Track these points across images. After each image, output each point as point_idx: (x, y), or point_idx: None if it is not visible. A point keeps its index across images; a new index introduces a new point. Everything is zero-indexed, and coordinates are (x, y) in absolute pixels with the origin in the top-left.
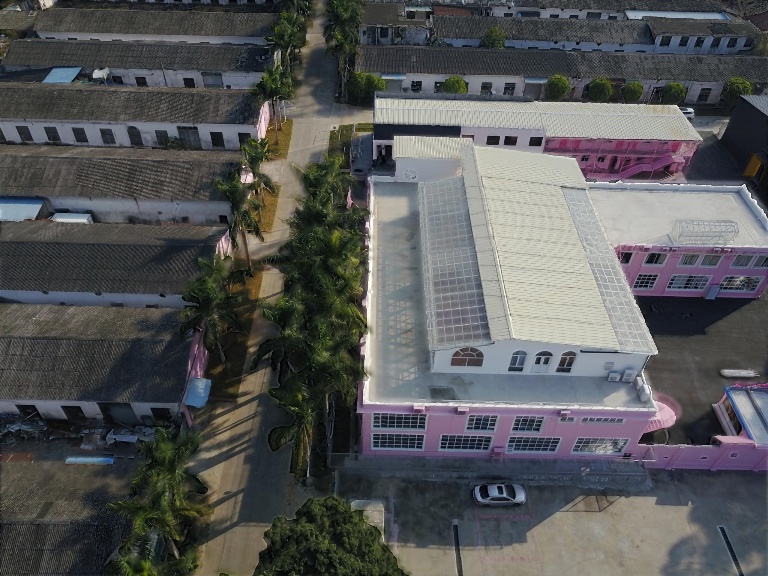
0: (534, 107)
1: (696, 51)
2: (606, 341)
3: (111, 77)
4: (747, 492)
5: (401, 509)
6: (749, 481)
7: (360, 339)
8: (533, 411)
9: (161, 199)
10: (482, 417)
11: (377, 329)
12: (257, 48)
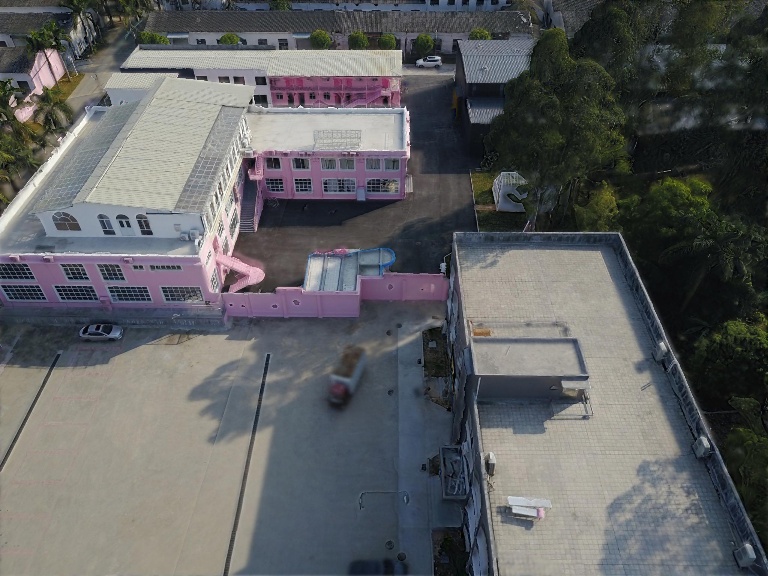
0: (270, 53)
1: (465, 9)
2: (165, 205)
3: None
4: (304, 331)
5: (21, 343)
6: (311, 324)
7: None
8: (104, 259)
9: None
10: (73, 267)
11: (23, 210)
12: (61, 14)
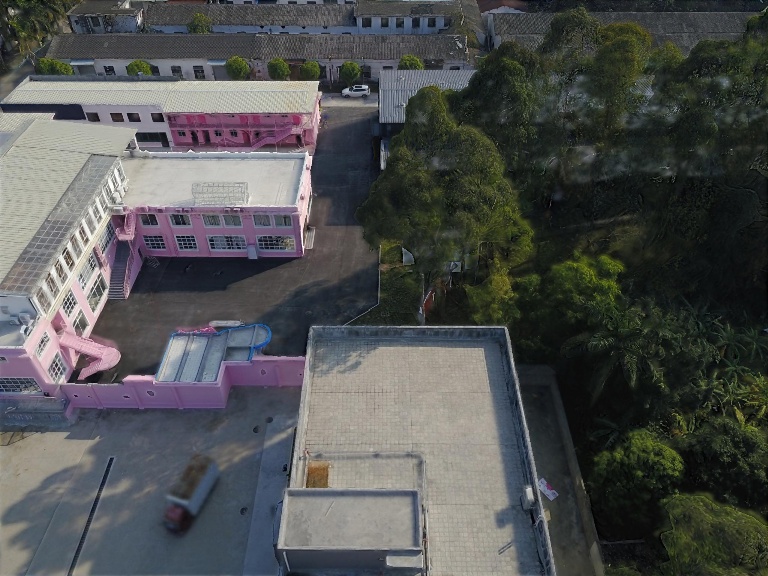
0: (172, 86)
1: (400, 32)
2: None
3: None
4: (159, 427)
5: None
6: (169, 418)
7: None
8: None
9: None
10: None
11: None
12: None
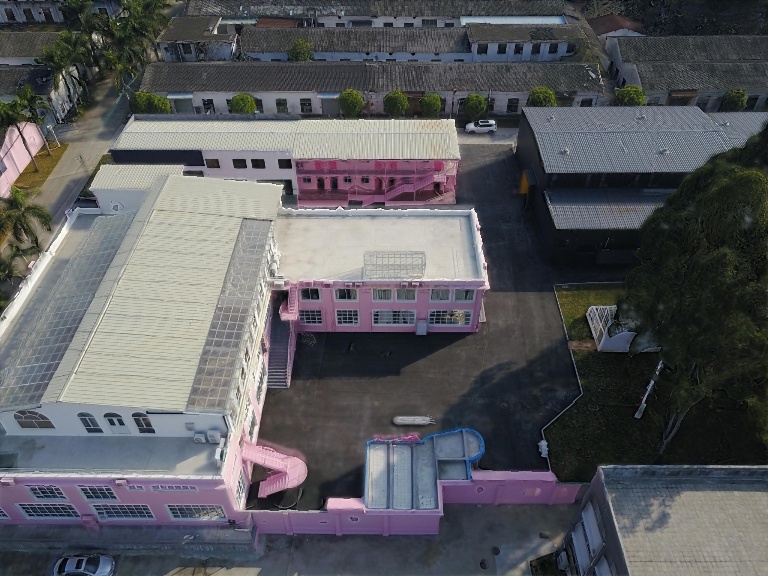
0: (295, 126)
1: (517, 58)
2: (172, 401)
3: None
4: (366, 561)
5: None
6: (374, 547)
7: None
8: (87, 480)
9: None
10: (43, 486)
11: None
12: (40, 70)
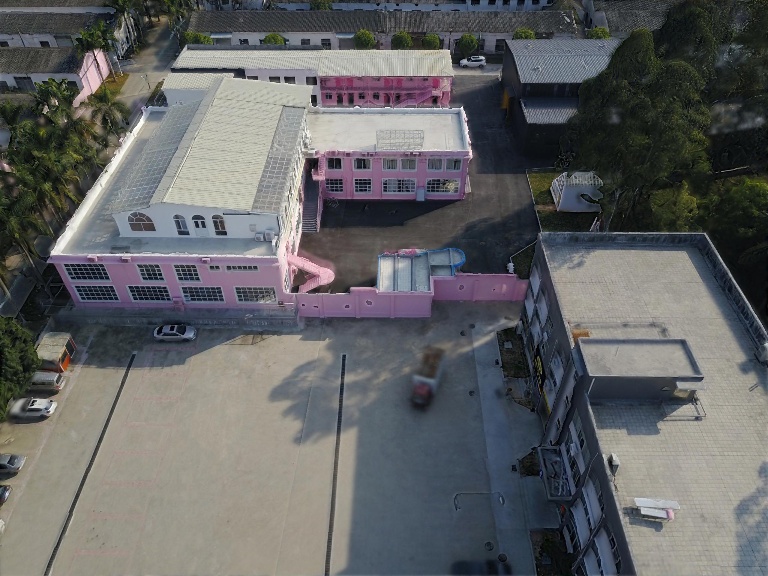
0: (319, 53)
1: (505, 9)
2: (242, 205)
3: None
4: (378, 332)
5: (95, 344)
6: (384, 325)
7: (72, 215)
8: (182, 259)
9: None
10: (149, 267)
11: (93, 210)
12: (104, 14)
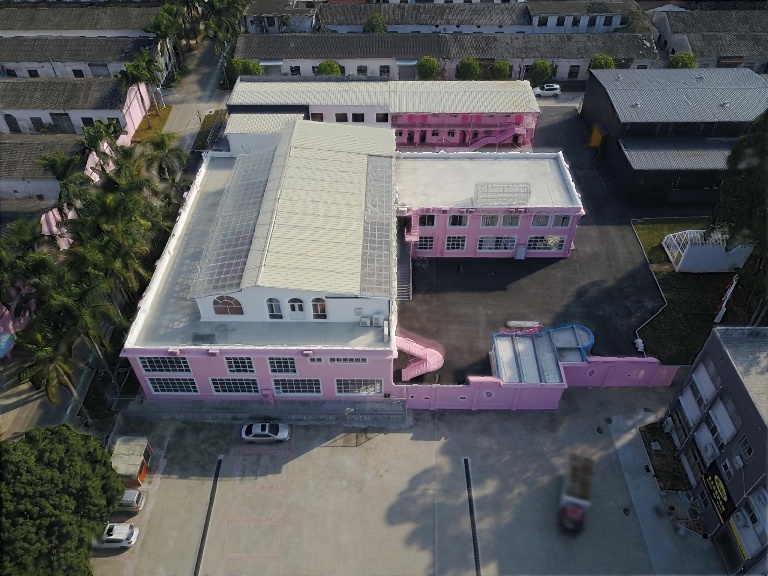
0: (387, 86)
1: (574, 30)
2: (348, 287)
3: (4, 71)
4: (500, 428)
5: (174, 446)
6: (505, 419)
7: (142, 293)
8: (279, 352)
9: (12, 178)
10: (238, 359)
11: (164, 285)
12: (142, 39)
